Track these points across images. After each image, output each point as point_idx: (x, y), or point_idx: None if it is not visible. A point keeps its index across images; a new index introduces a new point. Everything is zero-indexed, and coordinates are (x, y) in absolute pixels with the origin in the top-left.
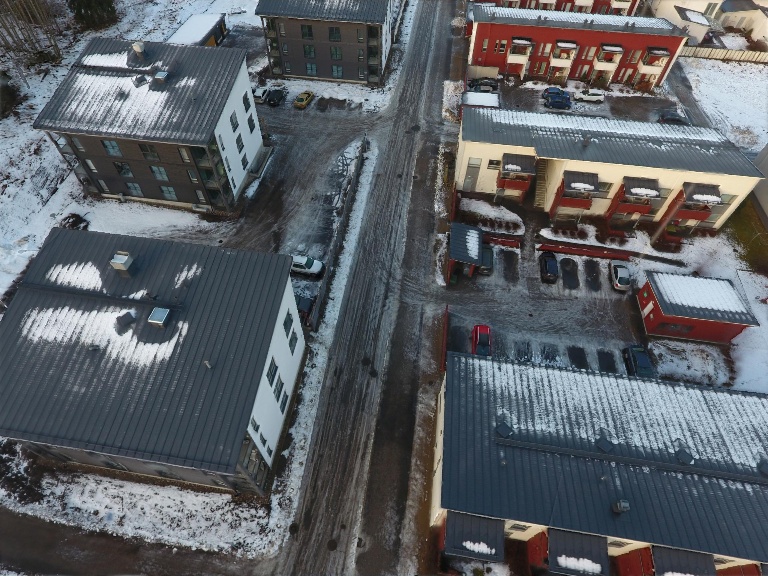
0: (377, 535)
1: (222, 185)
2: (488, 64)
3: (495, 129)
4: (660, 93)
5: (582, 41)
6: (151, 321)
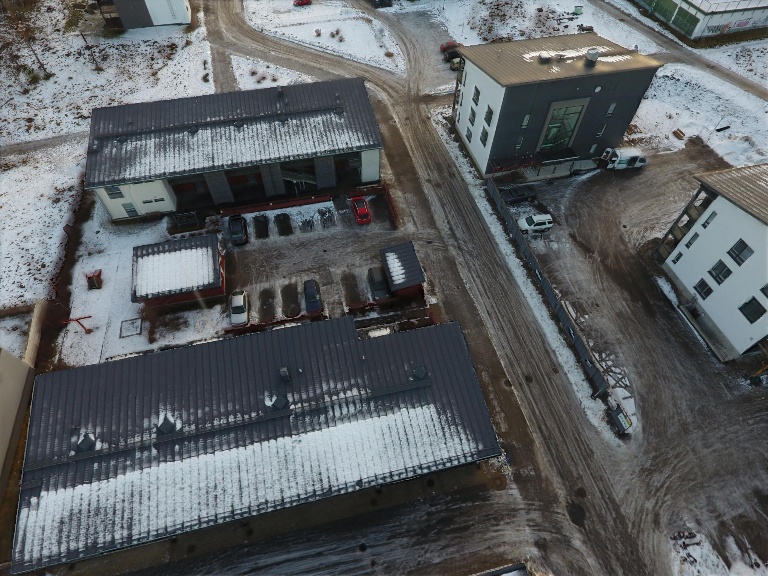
0: (388, 125)
1: (672, 231)
2: None
3: (424, 372)
4: None
5: None
6: None
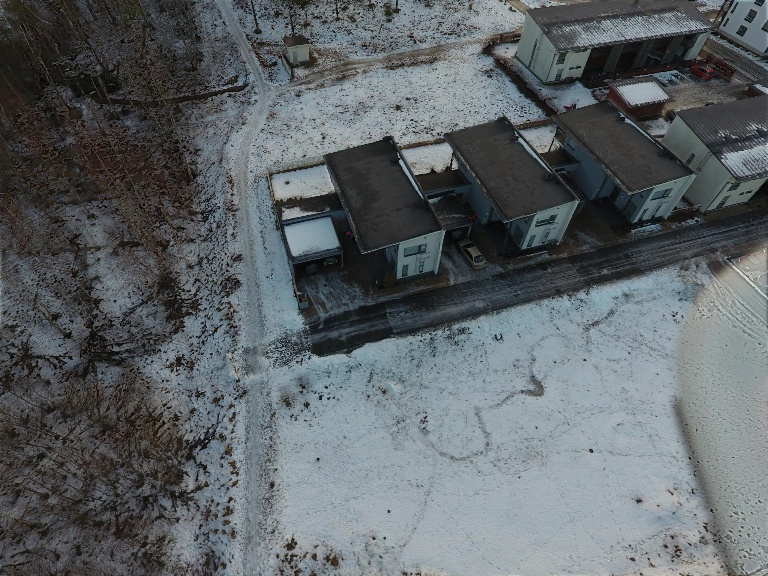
0: None
1: None
2: None
3: None
4: None
5: None
6: None
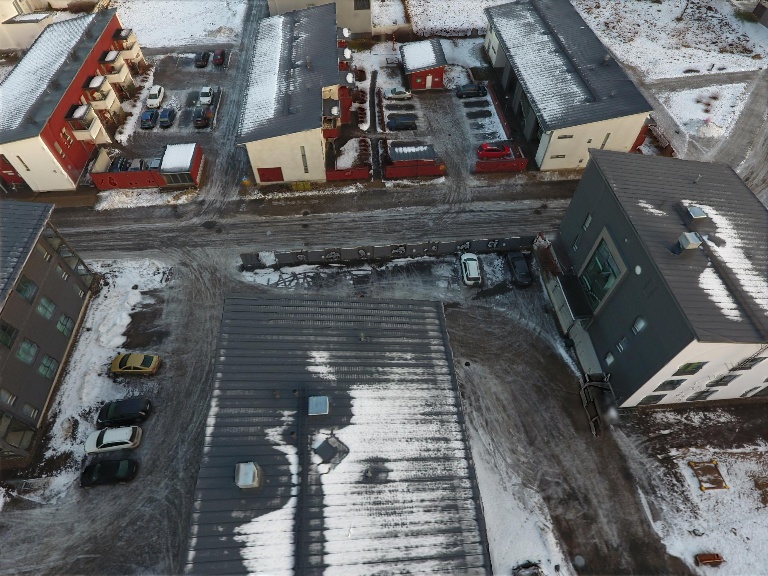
0: None
1: None
2: (76, 164)
3: (293, 112)
4: (150, 62)
5: (90, 72)
6: (705, 215)
